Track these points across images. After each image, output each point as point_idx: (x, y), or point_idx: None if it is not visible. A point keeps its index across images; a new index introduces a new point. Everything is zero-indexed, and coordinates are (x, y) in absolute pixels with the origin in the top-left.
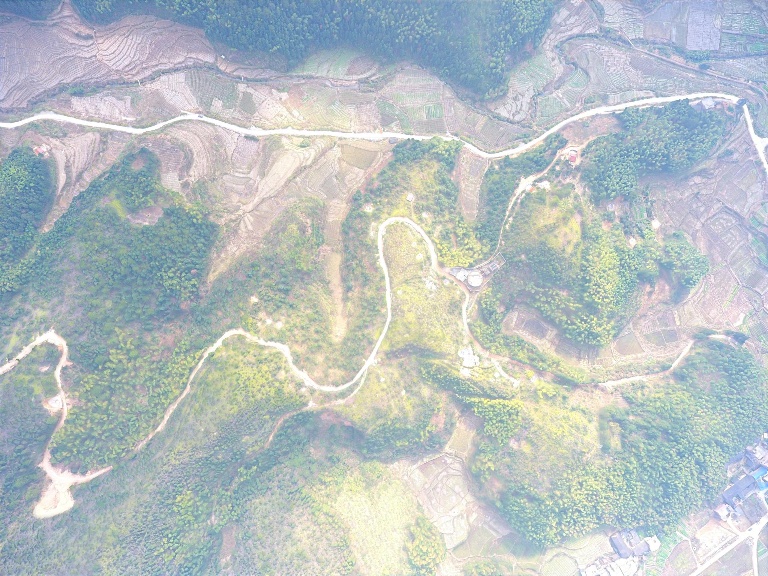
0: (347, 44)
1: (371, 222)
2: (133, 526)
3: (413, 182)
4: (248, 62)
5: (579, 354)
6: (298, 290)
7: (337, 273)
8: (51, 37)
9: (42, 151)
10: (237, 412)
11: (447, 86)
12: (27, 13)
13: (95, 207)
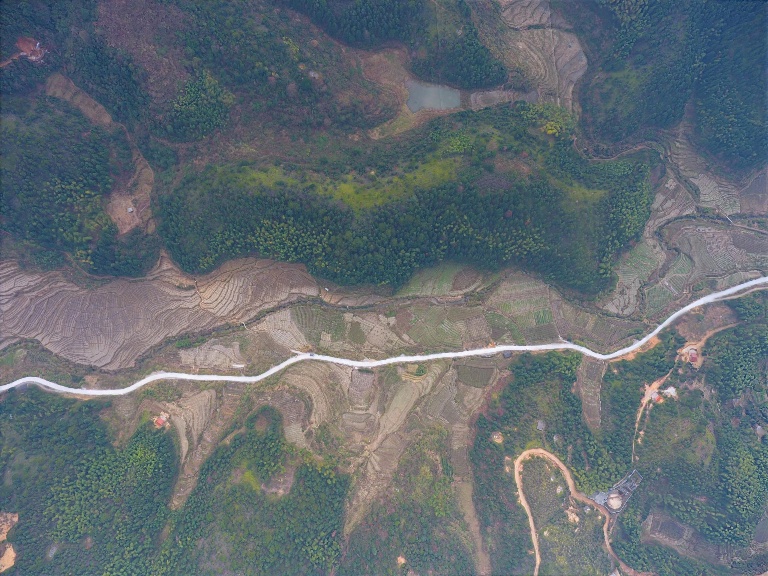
0: (450, 261)
1: (504, 456)
2: None
3: (540, 408)
4: (353, 292)
5: (718, 550)
6: (438, 535)
7: (470, 504)
8: (152, 291)
9: (162, 422)
10: None
11: (553, 288)
12: (128, 275)
13: (228, 483)
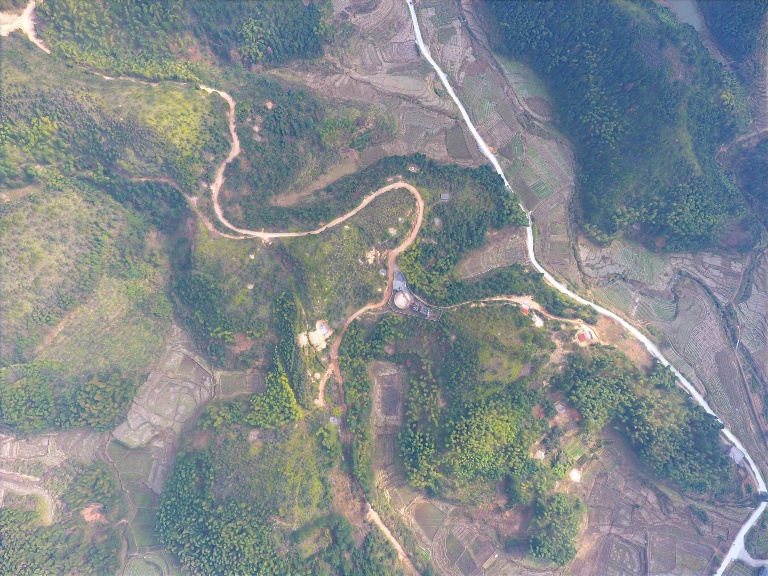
0: (550, 84)
1: (401, 174)
2: (1, 89)
3: (461, 193)
4: (481, 16)
5: (389, 464)
6: (301, 145)
7: (338, 176)
8: None
9: None
10: (150, 126)
11: (573, 189)
12: None
13: None
